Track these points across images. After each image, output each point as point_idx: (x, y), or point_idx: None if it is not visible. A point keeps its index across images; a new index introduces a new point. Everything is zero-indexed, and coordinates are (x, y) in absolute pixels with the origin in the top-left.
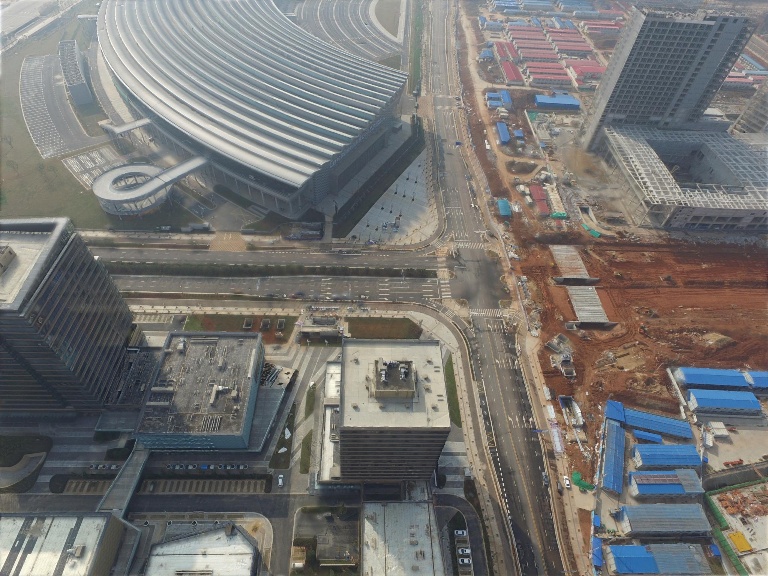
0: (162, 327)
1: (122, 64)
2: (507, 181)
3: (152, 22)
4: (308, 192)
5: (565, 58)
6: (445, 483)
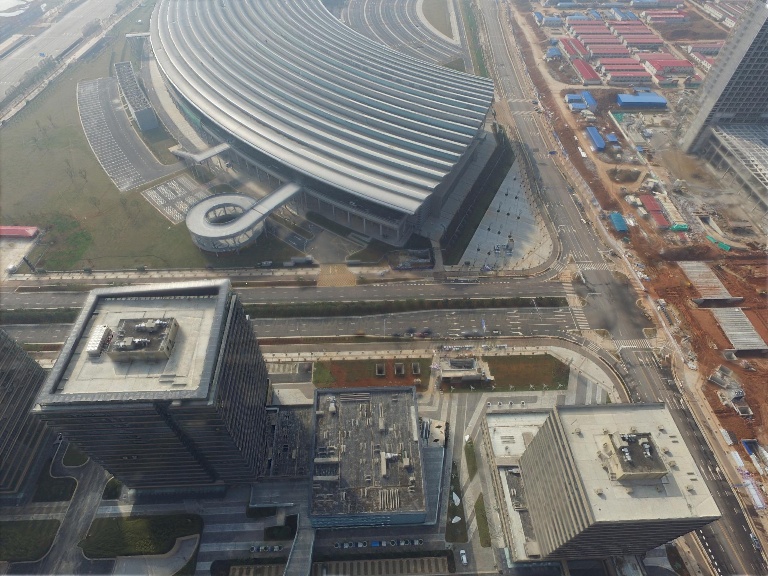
0: (289, 378)
1: (190, 86)
2: (613, 192)
3: (212, 39)
4: (411, 216)
5: (637, 52)
6: (646, 552)
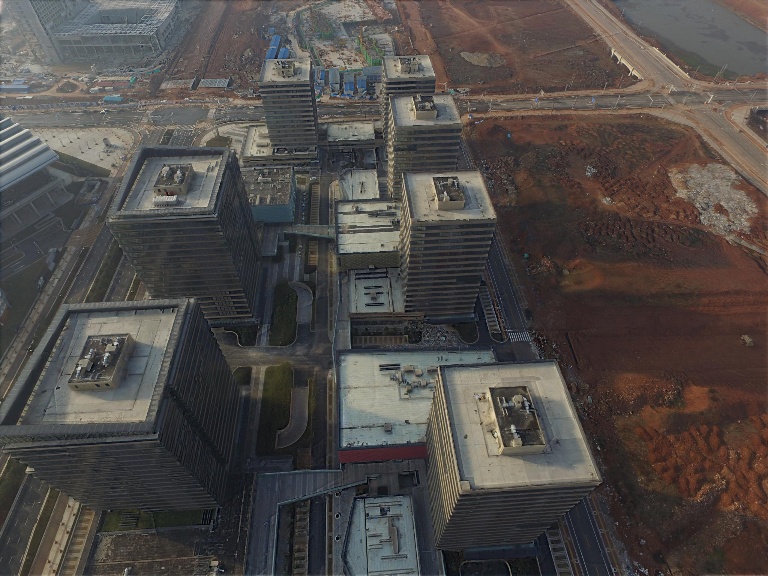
0: None
1: None
2: (81, 95)
3: None
4: None
5: None
6: None
